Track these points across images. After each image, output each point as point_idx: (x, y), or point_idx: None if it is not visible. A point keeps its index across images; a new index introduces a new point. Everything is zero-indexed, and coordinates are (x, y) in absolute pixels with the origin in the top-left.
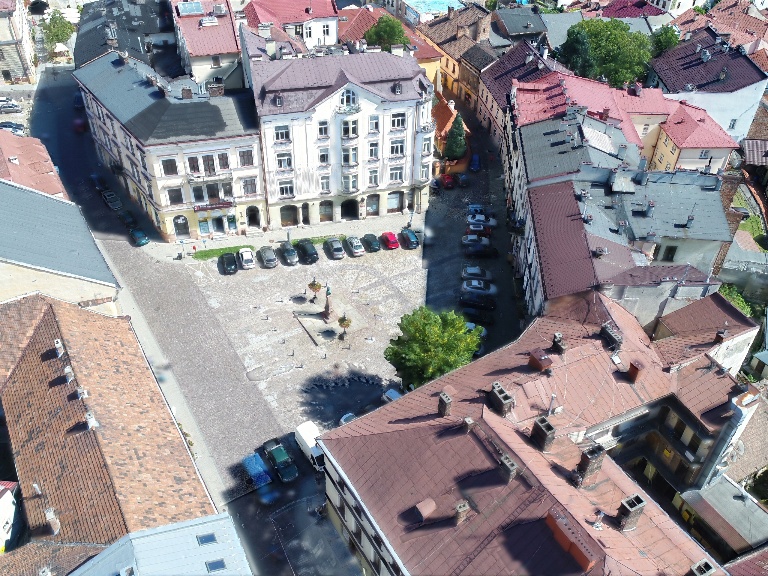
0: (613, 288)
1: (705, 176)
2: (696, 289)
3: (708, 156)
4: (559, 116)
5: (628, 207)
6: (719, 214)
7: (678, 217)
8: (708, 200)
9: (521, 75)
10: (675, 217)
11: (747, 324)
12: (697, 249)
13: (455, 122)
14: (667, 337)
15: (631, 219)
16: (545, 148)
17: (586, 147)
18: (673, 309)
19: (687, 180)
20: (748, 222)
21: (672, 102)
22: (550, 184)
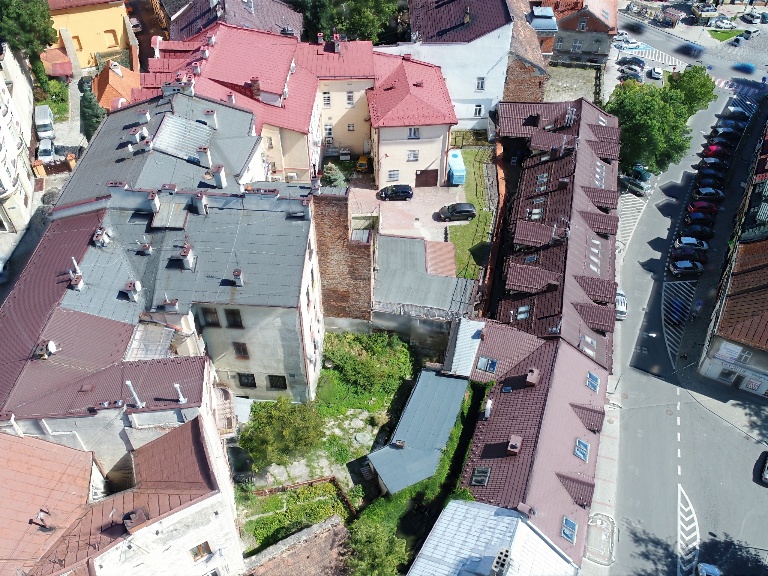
0: (21, 422)
1: (287, 199)
2: (163, 414)
3: (419, 135)
4: (156, 98)
5: (166, 253)
6: (295, 260)
7: (232, 267)
8: (289, 236)
9: (202, 25)
10: (228, 268)
11: (208, 483)
12: (268, 312)
13: (83, 99)
14: (119, 491)
15: (161, 274)
16: (108, 152)
17: (148, 152)
18: (145, 440)
19: (265, 205)
20: (473, 223)
21: (391, 58)
22: (79, 214)
